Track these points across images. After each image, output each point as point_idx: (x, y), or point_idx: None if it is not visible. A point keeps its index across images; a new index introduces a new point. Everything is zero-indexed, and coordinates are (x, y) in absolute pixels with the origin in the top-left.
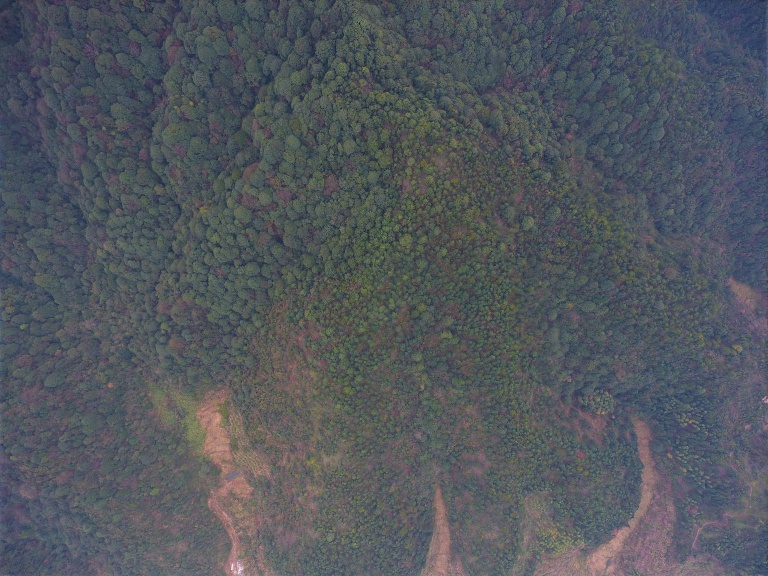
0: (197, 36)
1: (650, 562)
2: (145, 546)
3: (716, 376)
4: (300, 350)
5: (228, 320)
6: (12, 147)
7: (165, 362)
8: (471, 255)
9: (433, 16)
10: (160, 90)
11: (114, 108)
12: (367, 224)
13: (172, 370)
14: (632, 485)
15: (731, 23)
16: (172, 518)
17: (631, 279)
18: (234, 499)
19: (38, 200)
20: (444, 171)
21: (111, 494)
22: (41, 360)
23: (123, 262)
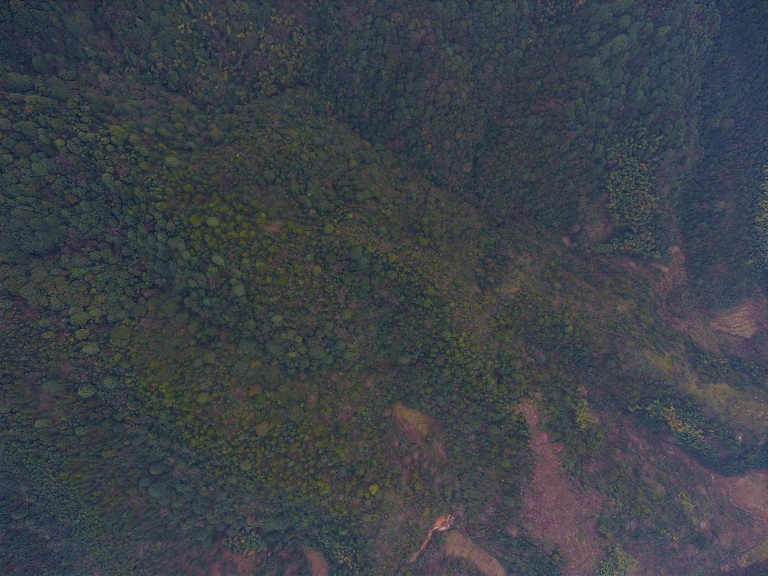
0: None
1: None
2: None
3: (352, 519)
4: None
5: None
6: None
7: None
8: None
9: None
10: None
11: None
12: None
13: None
14: None
15: (394, 144)
16: None
17: (203, 444)
18: None
19: None
20: None
21: None
22: None
23: None
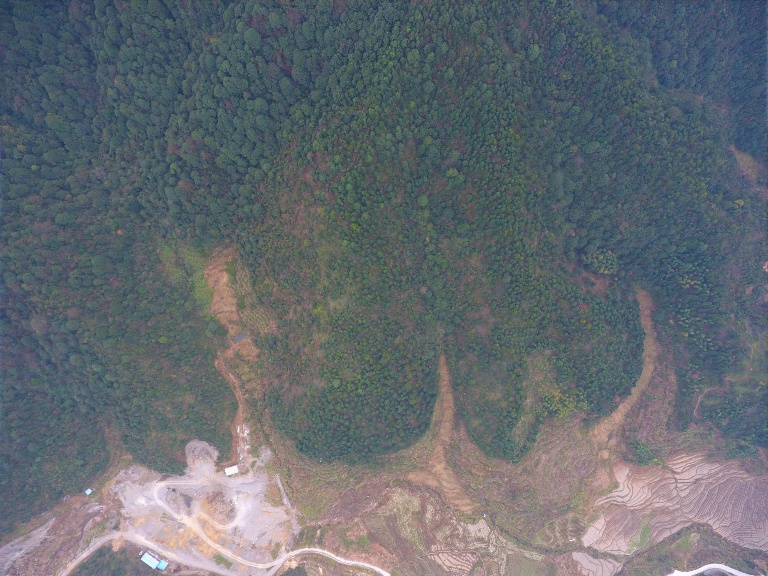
0: None
1: (652, 431)
2: (153, 391)
3: (718, 230)
4: (308, 185)
5: (236, 167)
6: None
7: (174, 207)
8: (478, 74)
9: None
10: None
11: None
12: (375, 44)
13: (180, 220)
14: (634, 351)
15: None
16: (180, 369)
17: (635, 111)
18: (240, 361)
19: (50, 34)
20: None
21: (120, 334)
22: (52, 202)
23: (133, 102)
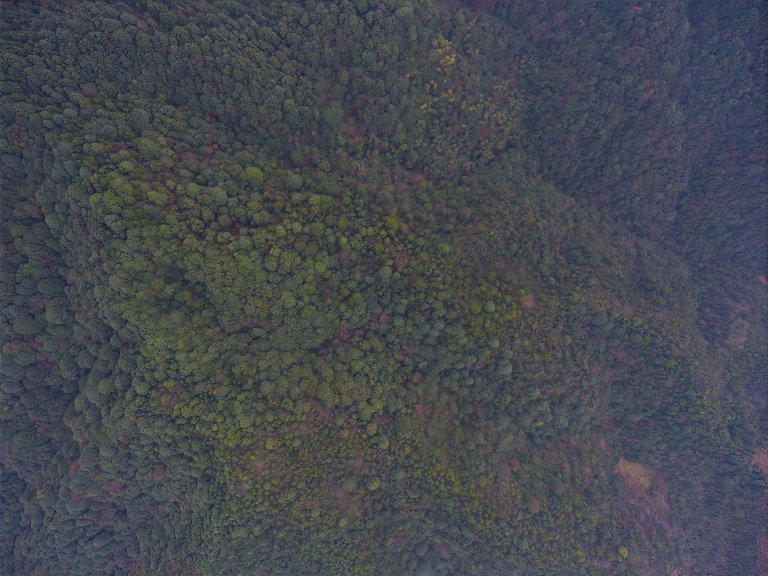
0: None
1: None
2: None
3: None
4: None
5: (92, 575)
6: None
7: None
8: None
9: (243, 305)
10: None
11: None
12: (200, 512)
13: None
14: None
15: (599, 199)
16: None
17: (488, 527)
18: None
19: None
20: (262, 474)
21: None
22: None
23: None
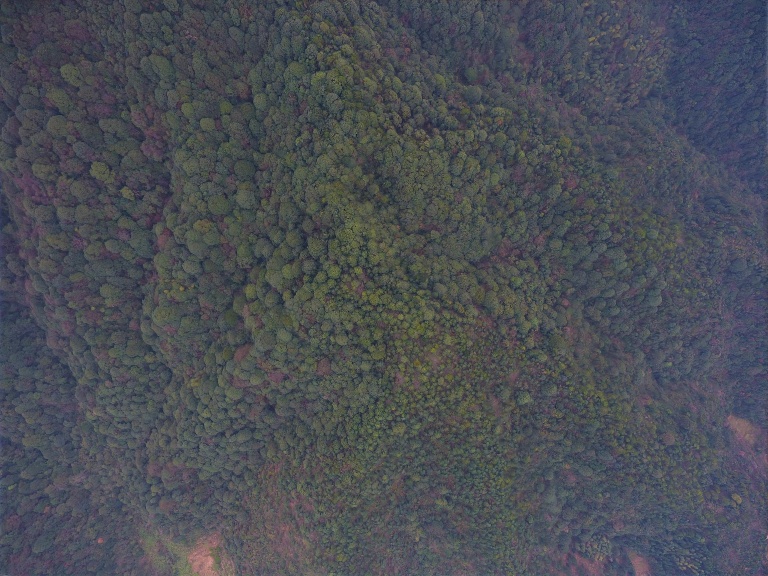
0: (187, 230)
1: None
2: None
3: (715, 527)
4: (292, 518)
5: (220, 475)
6: (0, 319)
7: (156, 520)
8: (466, 440)
9: (427, 205)
10: (150, 267)
11: (103, 290)
12: (360, 408)
13: (163, 523)
14: None
15: (729, 156)
16: None
17: (628, 452)
18: None
19: (26, 367)
20: (438, 368)
21: None
22: (29, 520)
23: (113, 424)
